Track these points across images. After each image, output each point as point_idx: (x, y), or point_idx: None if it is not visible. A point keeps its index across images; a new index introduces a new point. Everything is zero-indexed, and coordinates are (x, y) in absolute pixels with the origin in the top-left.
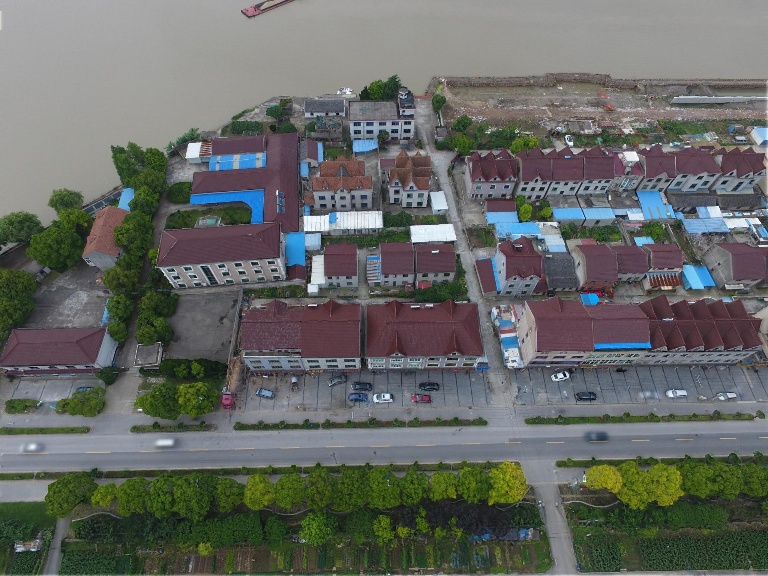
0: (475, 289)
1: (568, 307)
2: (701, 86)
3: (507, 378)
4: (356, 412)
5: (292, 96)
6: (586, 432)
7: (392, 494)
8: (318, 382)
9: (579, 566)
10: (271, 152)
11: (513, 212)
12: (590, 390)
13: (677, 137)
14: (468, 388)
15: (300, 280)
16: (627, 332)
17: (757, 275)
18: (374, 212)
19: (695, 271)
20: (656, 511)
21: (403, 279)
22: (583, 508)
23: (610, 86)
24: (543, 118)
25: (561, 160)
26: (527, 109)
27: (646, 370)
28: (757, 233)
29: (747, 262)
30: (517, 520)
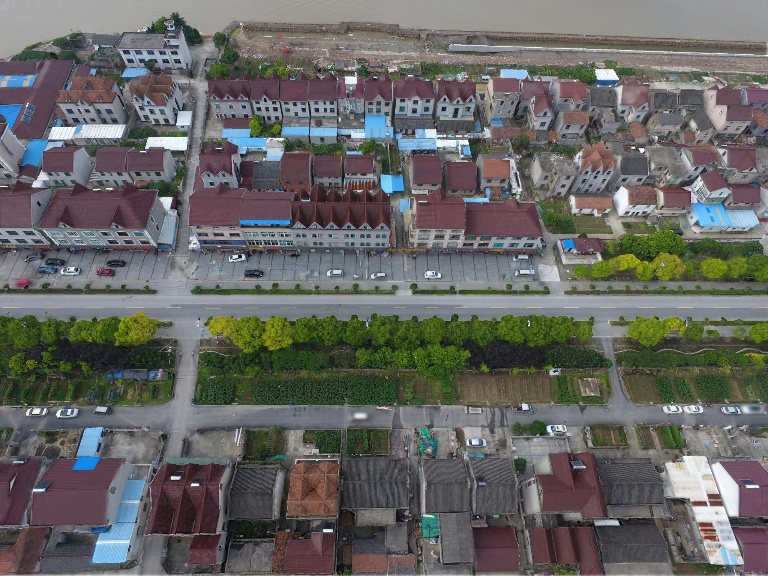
0: (192, 190)
1: (229, 192)
2: (480, 37)
3: (190, 259)
4: (42, 282)
5: (92, 33)
6: (243, 301)
7: (26, 333)
8: (17, 259)
9: (194, 399)
10: (40, 74)
11: (247, 129)
12: (260, 269)
13: (434, 76)
14: (152, 266)
15: (28, 178)
16: (271, 211)
17: (435, 180)
18: (118, 125)
19: (391, 179)
20: (263, 353)
21: (121, 178)
22: (204, 352)
23: (396, 34)
24: (320, 58)
25: (288, 82)
26: (309, 50)
27: (317, 255)
28: (461, 151)
29: (426, 169)
30: (138, 358)
